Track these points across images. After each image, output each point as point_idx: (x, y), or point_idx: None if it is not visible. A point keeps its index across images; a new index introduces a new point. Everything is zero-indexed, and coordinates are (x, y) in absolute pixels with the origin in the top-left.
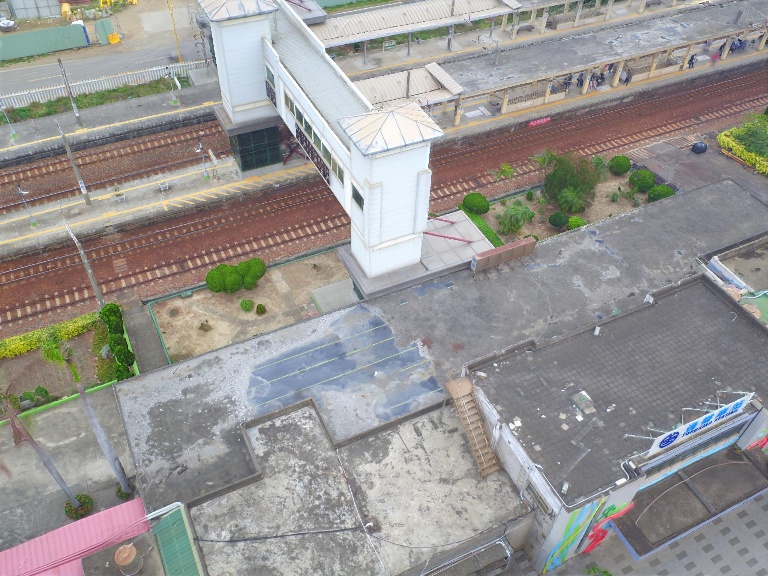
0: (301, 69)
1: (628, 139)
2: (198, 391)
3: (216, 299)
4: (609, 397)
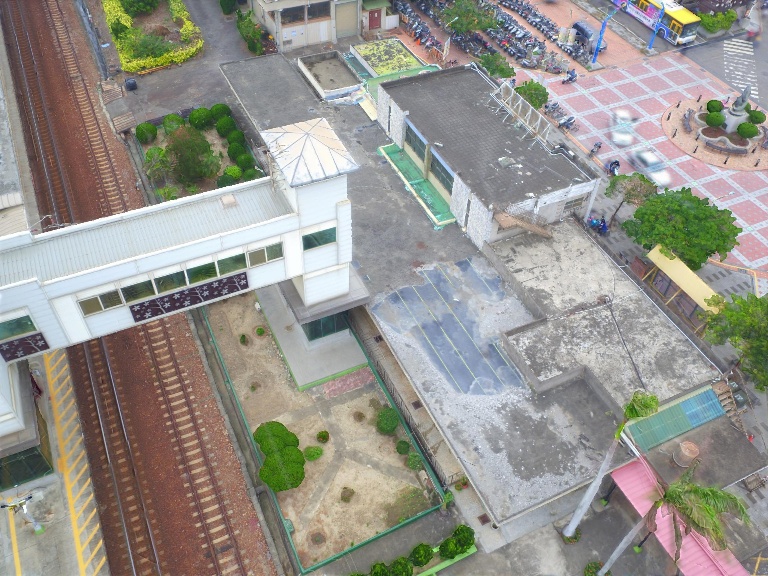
0: (63, 265)
1: (89, 125)
2: (495, 438)
3: (297, 492)
4: (499, 150)
